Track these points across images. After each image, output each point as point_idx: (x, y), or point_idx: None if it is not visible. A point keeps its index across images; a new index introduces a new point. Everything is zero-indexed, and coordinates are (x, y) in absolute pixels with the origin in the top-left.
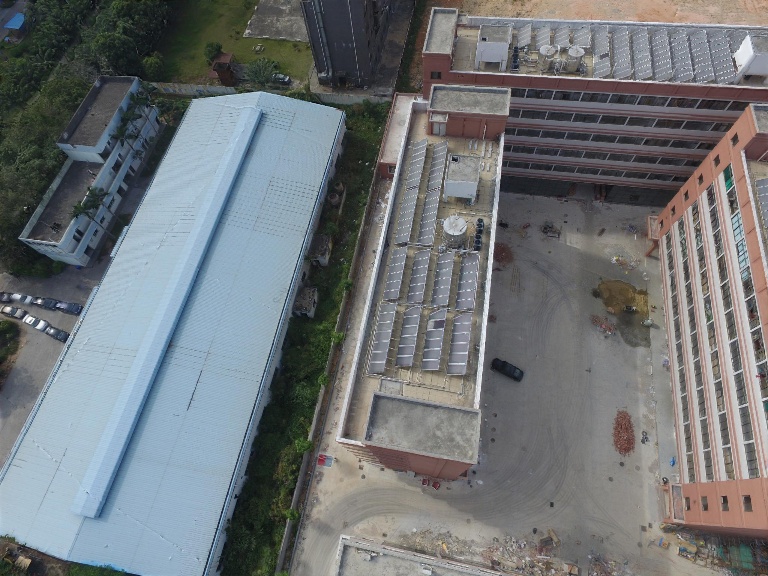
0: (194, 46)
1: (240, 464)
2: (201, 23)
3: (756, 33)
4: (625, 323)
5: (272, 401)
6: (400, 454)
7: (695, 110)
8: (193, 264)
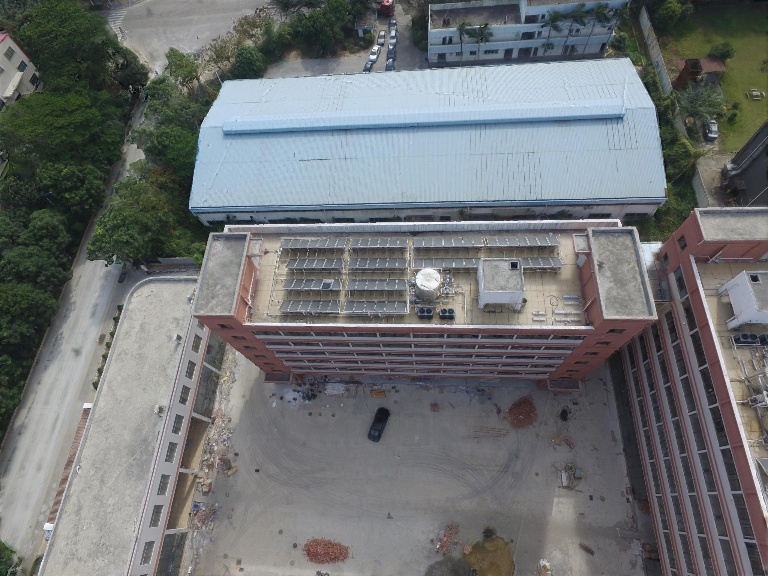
0: (729, 36)
1: (267, 209)
2: None
3: None
4: (455, 568)
5: None
6: None
7: None
8: (419, 119)
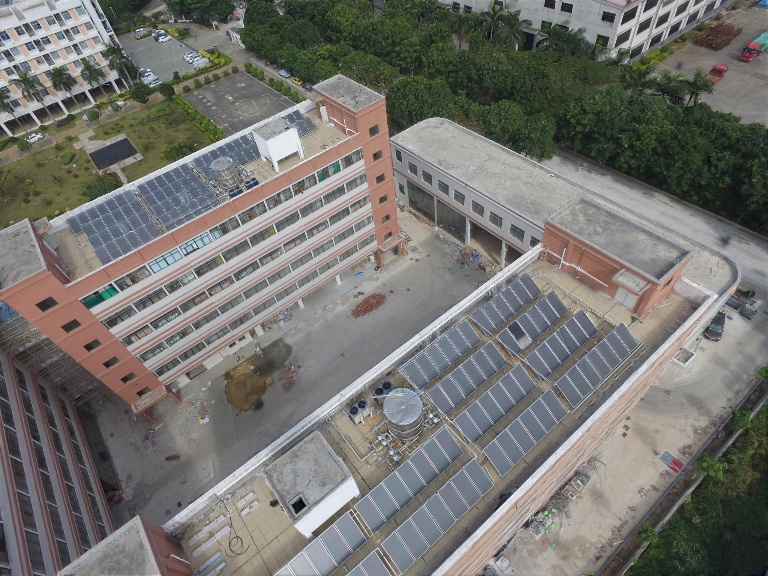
0: None
1: None
2: None
3: None
4: (272, 366)
5: None
6: None
7: None
8: None
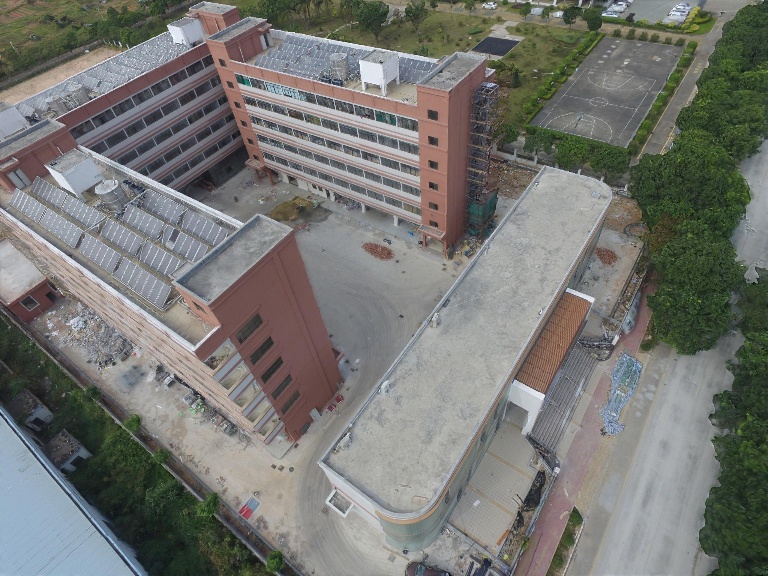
0: None
1: None
2: None
3: None
4: (307, 216)
5: (138, 549)
6: (254, 309)
7: (190, 78)
8: None
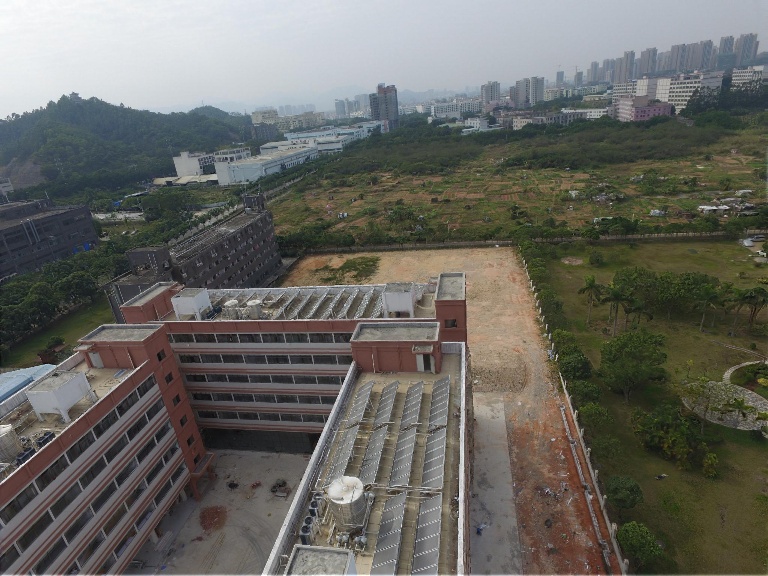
0: None
1: None
2: (71, 328)
3: (416, 288)
4: None
5: None
6: None
7: None
8: None
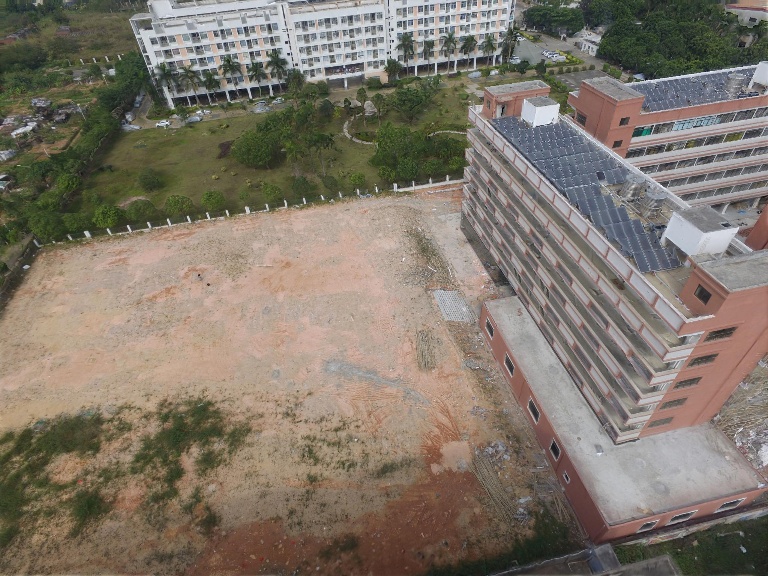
0: None
1: None
2: None
3: None
4: None
5: None
6: None
7: None
8: None
